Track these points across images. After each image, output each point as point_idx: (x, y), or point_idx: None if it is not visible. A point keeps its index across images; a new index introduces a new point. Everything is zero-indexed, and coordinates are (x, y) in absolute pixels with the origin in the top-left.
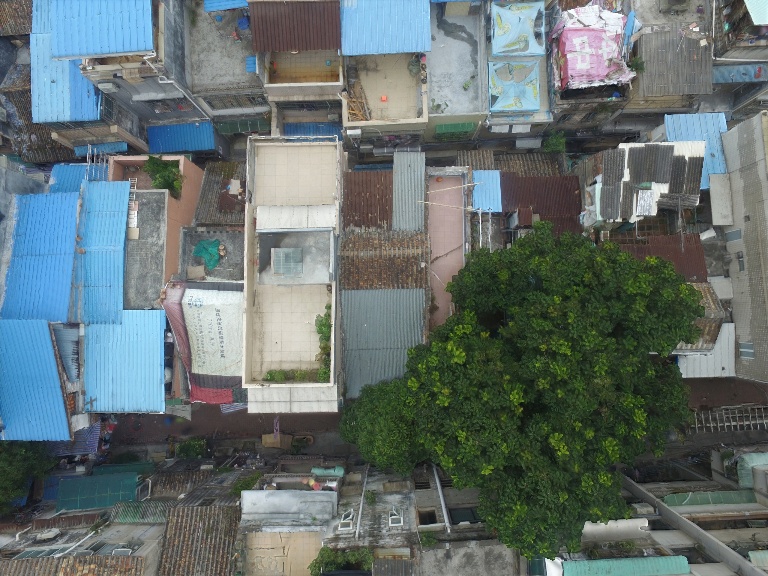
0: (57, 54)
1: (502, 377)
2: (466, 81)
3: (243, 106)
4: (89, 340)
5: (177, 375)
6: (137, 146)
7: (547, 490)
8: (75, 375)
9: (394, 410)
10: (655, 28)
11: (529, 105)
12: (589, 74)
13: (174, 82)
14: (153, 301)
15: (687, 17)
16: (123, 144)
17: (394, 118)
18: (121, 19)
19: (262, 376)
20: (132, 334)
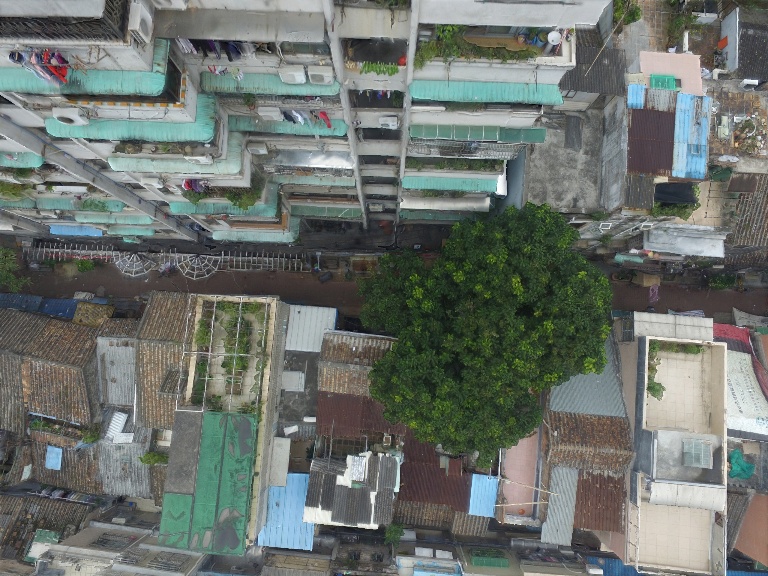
0: None
1: (554, 342)
2: None
3: None
4: None
5: (767, 355)
6: None
7: (540, 256)
8: None
9: None
10: None
11: None
12: None
13: None
14: None
15: None
16: None
17: None
18: None
19: None
20: None
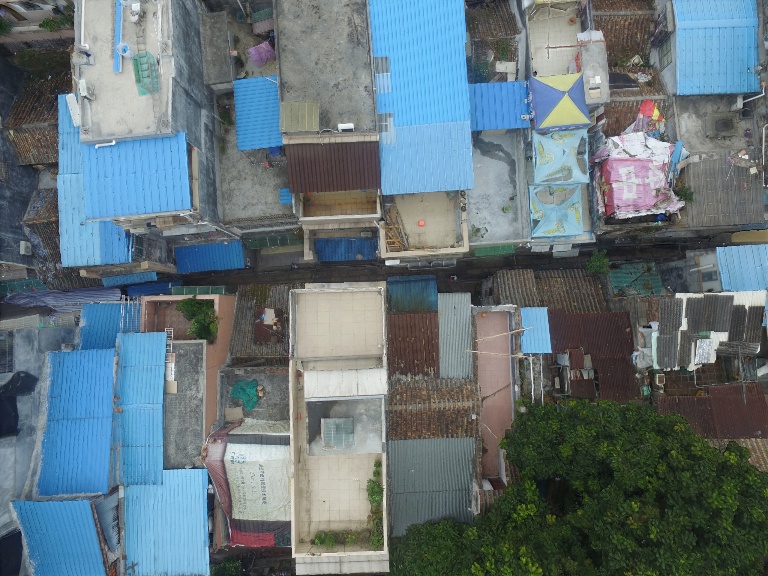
0: (91, 216)
1: None
2: (505, 203)
3: (273, 226)
4: (129, 502)
5: (218, 525)
6: (166, 272)
7: None
8: (116, 542)
9: (445, 559)
10: (703, 156)
11: (572, 230)
12: (636, 204)
13: (208, 223)
14: (194, 457)
15: (735, 142)
16: (152, 274)
17: (434, 249)
18: (157, 178)
19: (310, 537)
20: (173, 495)
